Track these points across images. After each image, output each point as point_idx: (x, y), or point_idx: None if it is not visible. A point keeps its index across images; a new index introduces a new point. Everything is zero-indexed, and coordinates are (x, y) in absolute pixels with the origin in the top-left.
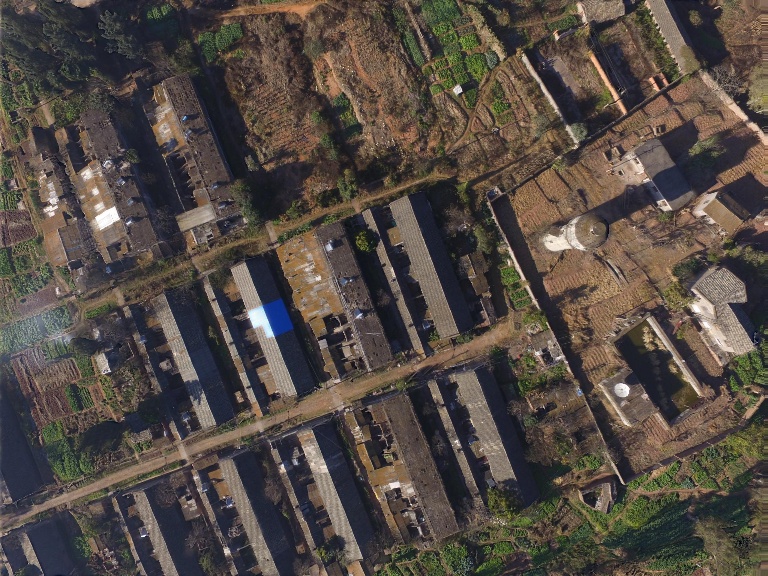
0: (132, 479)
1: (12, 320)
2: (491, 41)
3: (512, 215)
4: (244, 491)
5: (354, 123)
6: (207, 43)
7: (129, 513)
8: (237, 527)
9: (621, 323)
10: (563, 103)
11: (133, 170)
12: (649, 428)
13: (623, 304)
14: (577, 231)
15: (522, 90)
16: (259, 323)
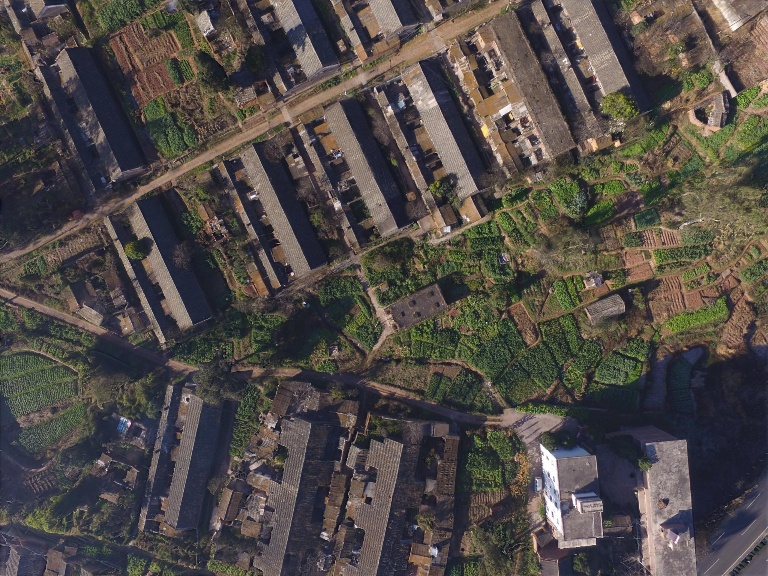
0: (237, 148)
1: (109, 0)
2: None
3: None
4: (353, 135)
5: None
6: None
7: (237, 177)
8: (346, 180)
9: None
10: None
11: None
12: (757, 36)
13: None
14: None
15: None
16: None
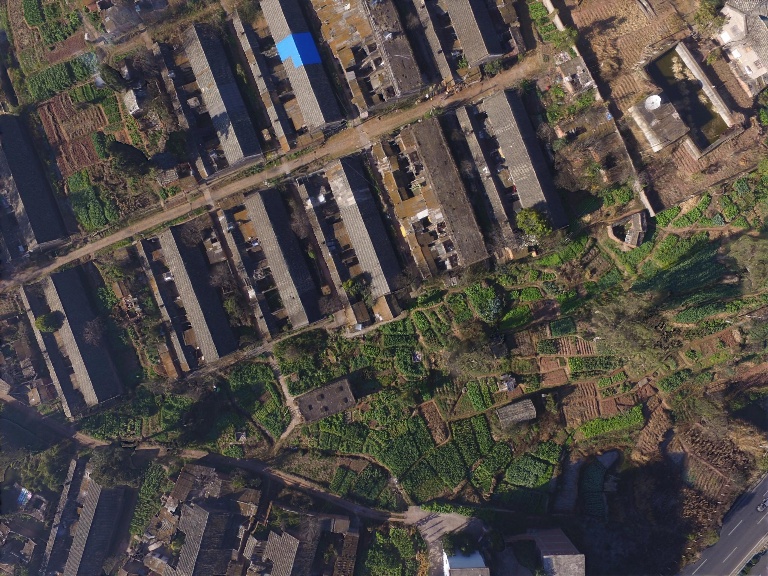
0: (157, 226)
1: (40, 69)
2: None
3: None
4: (270, 226)
5: None
6: None
7: (154, 257)
8: (262, 269)
9: (650, 52)
10: None
11: None
12: (679, 158)
13: (652, 35)
14: None
15: None
16: (288, 54)
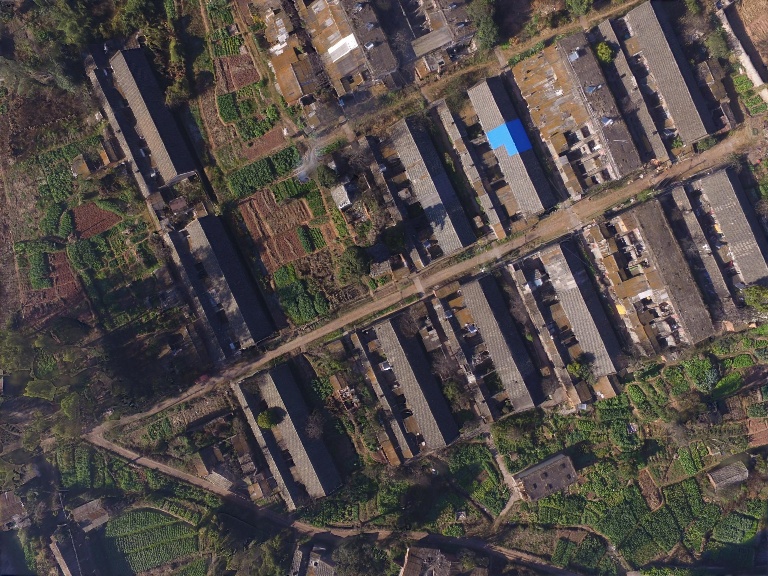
0: (368, 316)
1: (239, 165)
2: None
3: (740, 25)
4: (491, 313)
5: None
6: None
7: (370, 348)
8: (480, 354)
9: None
10: None
11: None
12: None
13: None
14: None
15: None
16: (500, 142)
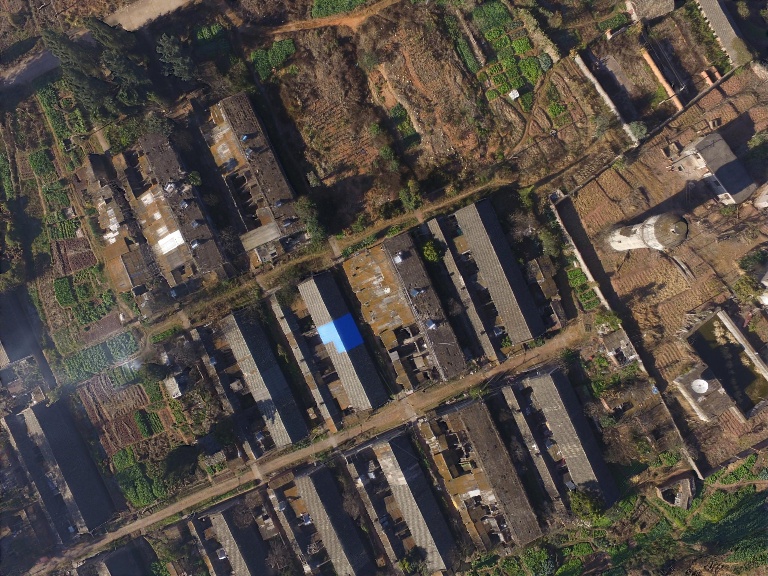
0: (206, 501)
1: (76, 349)
2: (544, 44)
3: (575, 217)
4: (322, 507)
5: (412, 133)
6: (260, 61)
7: (206, 536)
8: (316, 544)
9: (691, 319)
10: (618, 102)
11: (195, 192)
12: (725, 422)
13: (692, 300)
14: (657, 231)
15: (578, 91)
16: (329, 339)
